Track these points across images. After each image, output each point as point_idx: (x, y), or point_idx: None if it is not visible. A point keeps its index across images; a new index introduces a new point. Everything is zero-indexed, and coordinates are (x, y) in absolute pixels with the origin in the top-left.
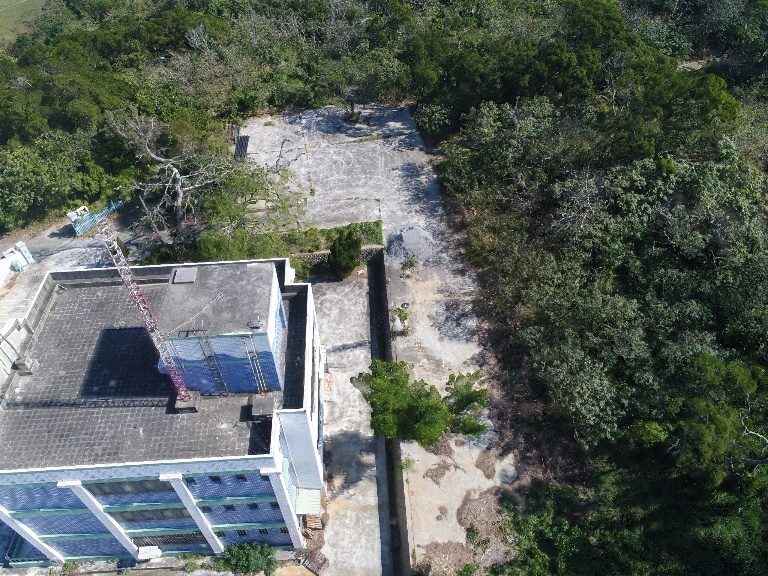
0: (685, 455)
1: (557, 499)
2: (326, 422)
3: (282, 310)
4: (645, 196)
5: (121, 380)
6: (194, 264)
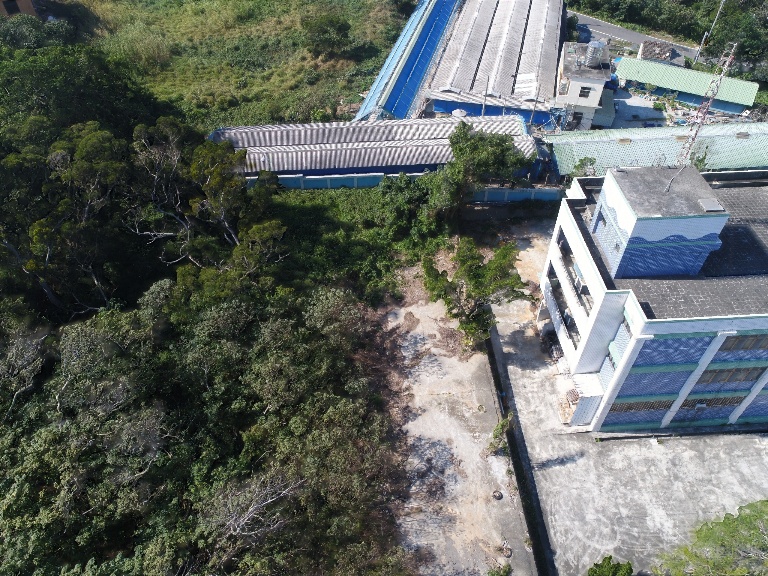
0: (281, 247)
1: (362, 295)
2: (555, 376)
3: (618, 255)
4: (121, 567)
5: (726, 235)
6: (749, 315)
